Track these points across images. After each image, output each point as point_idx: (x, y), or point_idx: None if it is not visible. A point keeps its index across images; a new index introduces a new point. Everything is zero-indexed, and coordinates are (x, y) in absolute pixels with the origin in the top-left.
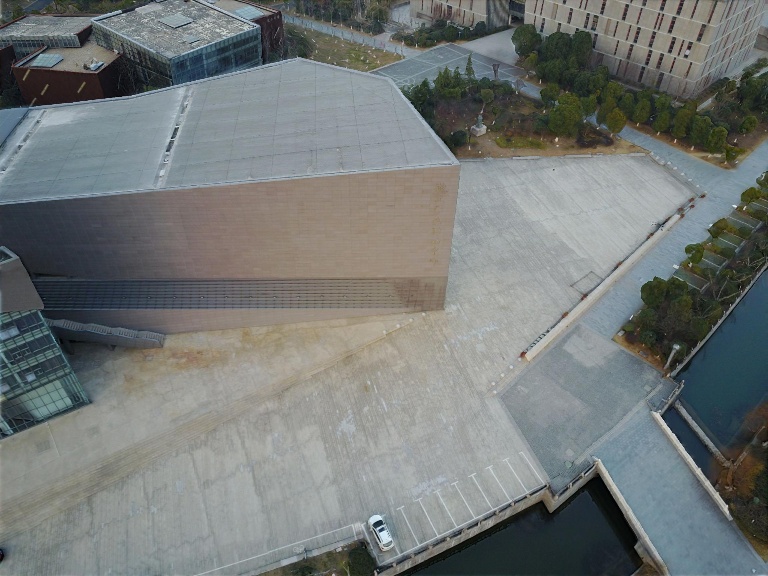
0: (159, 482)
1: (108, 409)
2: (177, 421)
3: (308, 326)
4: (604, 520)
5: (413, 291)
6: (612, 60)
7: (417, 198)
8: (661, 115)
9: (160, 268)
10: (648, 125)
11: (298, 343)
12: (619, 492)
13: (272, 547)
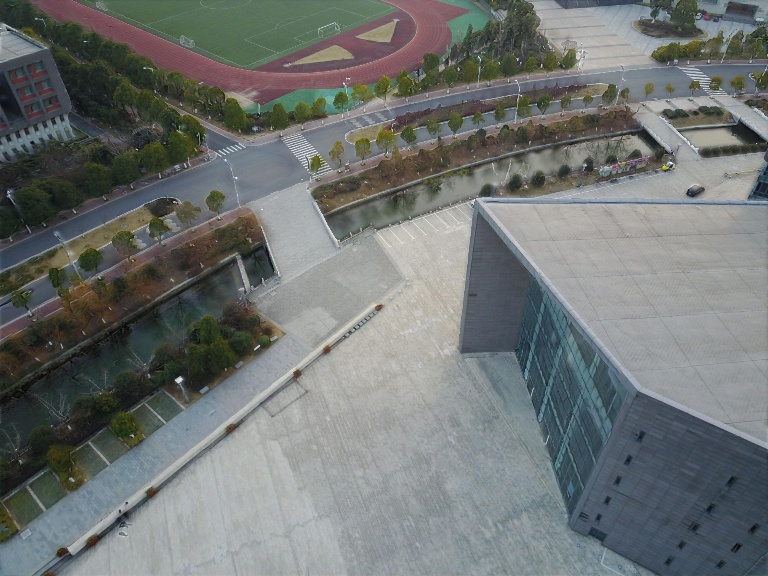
0: None
1: None
2: None
3: None
4: None
5: None
6: None
7: None
8: None
9: None
10: None
11: None
12: None
13: None
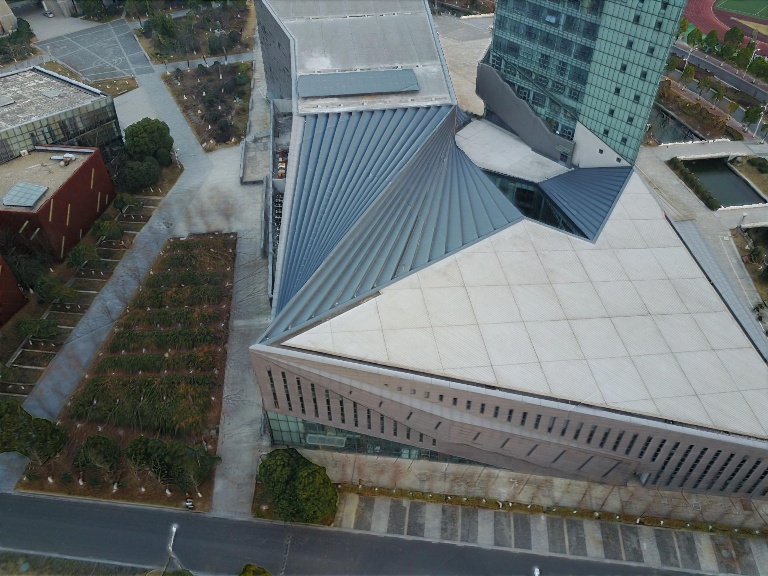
0: None
1: None
2: None
3: None
4: None
5: None
6: None
7: None
8: None
9: None
10: None
11: None
12: None
13: None
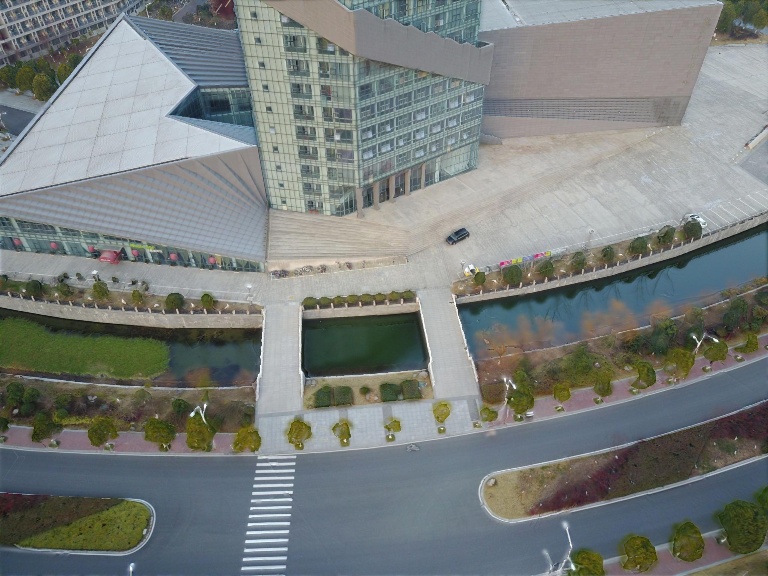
0: (541, 205)
1: (489, 171)
2: (537, 176)
3: (592, 134)
4: None
5: (664, 109)
6: None
7: (689, 30)
8: None
9: (503, 89)
10: None
11: (591, 142)
12: None
13: (630, 229)
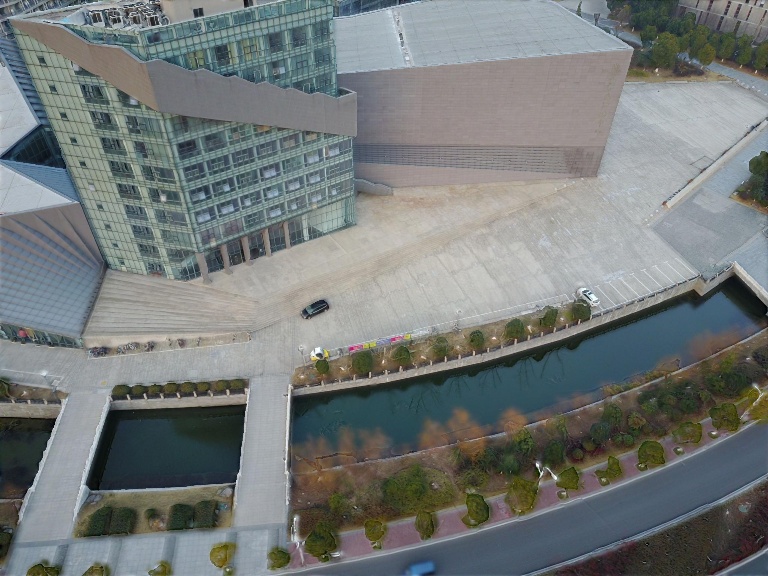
0: (420, 271)
1: (369, 229)
2: (422, 236)
3: (497, 185)
4: (737, 307)
5: (577, 159)
6: (694, 12)
7: (597, 76)
8: (745, 50)
9: (394, 134)
10: (732, 60)
11: (493, 194)
12: (753, 279)
13: (513, 305)
